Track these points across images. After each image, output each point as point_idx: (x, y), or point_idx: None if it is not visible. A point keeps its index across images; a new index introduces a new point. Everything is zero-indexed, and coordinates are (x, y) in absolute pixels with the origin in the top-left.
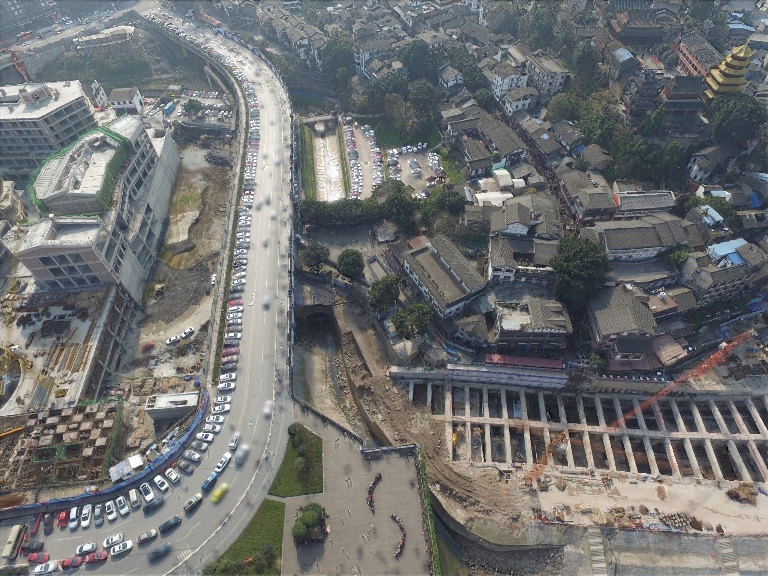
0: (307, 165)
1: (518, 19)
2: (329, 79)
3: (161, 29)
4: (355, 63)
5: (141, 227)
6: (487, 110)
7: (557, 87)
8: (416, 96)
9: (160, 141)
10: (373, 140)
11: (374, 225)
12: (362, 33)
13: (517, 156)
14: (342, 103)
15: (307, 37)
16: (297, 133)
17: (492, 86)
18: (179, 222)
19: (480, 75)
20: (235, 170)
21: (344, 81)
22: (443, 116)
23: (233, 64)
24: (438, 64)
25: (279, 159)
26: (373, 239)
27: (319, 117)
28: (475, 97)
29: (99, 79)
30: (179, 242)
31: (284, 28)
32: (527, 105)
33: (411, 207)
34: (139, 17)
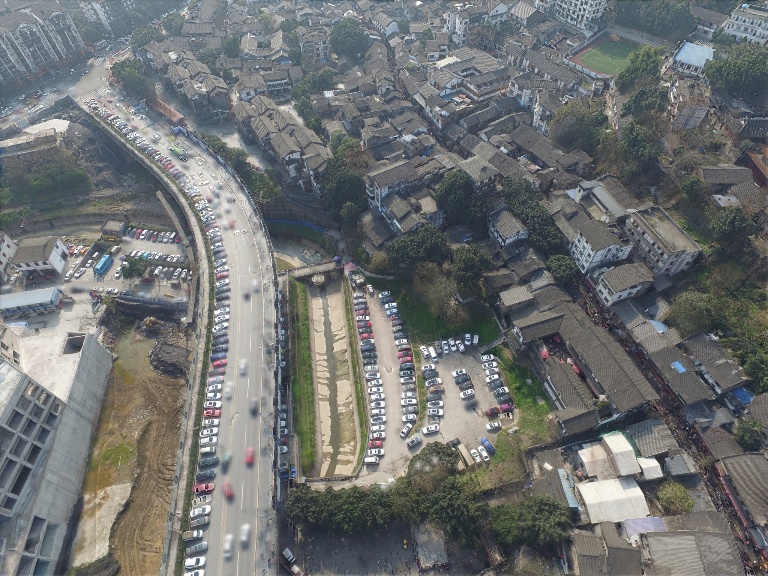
0: (301, 363)
1: (596, 130)
2: (330, 214)
3: (103, 128)
4: (367, 195)
5: (19, 570)
6: (567, 287)
7: (681, 267)
8: (463, 273)
9: (72, 362)
10: (397, 323)
11: (410, 524)
12: (374, 141)
13: (638, 406)
14: (349, 242)
15: (299, 150)
16: (286, 313)
17: (572, 247)
18: (97, 511)
19: (555, 232)
20: (186, 427)
21: (352, 221)
22: (504, 302)
23: (196, 191)
24: (489, 209)
25: (257, 397)
26: (411, 559)
27: (317, 266)
28: (549, 268)
29: (17, 201)
30: (93, 563)
31: (267, 133)
32: (634, 292)
33: (476, 522)
34: (77, 105)
